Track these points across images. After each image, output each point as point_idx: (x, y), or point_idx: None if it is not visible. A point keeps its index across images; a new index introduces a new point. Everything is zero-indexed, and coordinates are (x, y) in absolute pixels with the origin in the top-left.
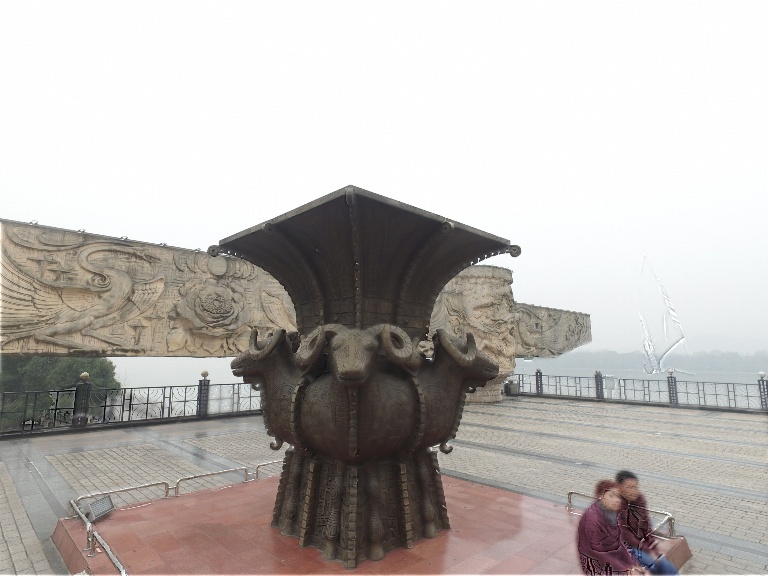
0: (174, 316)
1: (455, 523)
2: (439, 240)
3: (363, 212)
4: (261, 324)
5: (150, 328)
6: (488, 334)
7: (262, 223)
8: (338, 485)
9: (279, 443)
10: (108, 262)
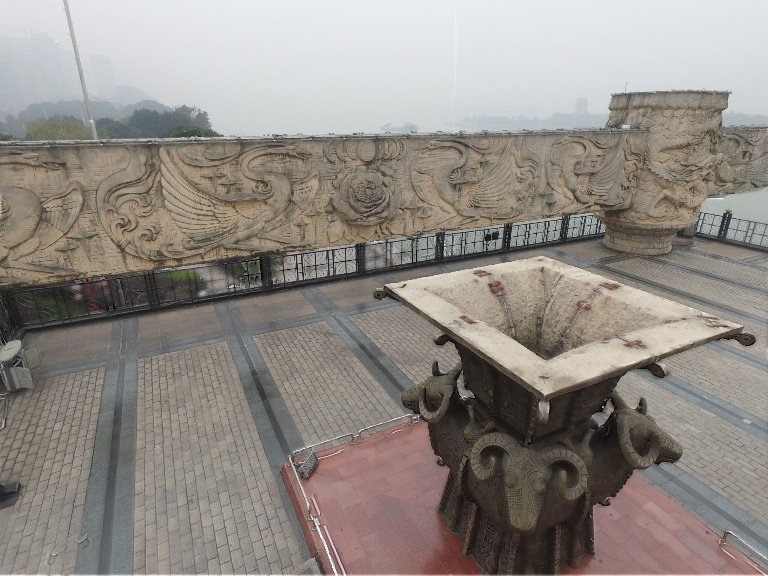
0: (331, 210)
1: (599, 545)
2: None
3: None
4: (412, 205)
5: (312, 224)
6: (672, 183)
7: (432, 319)
8: (498, 540)
9: None
10: (266, 166)
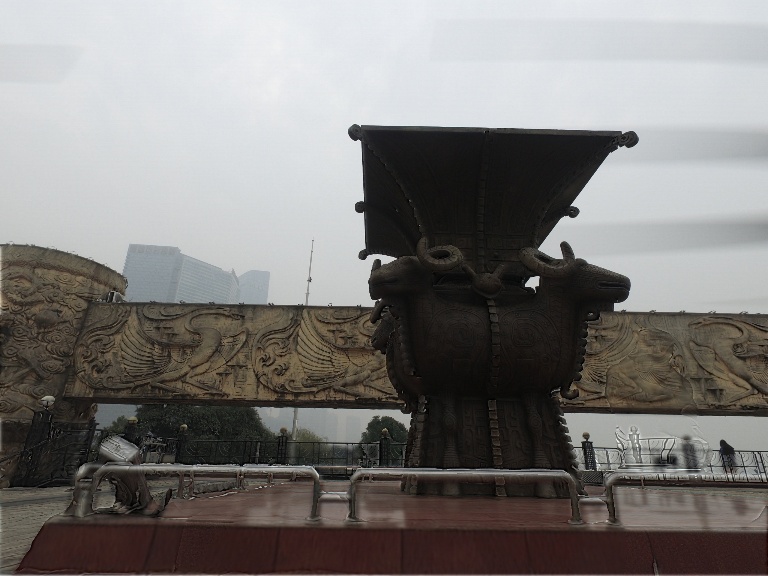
0: None
1: None
2: (502, 157)
3: (387, 147)
4: None
5: None
6: None
7: None
8: None
9: (407, 405)
10: None
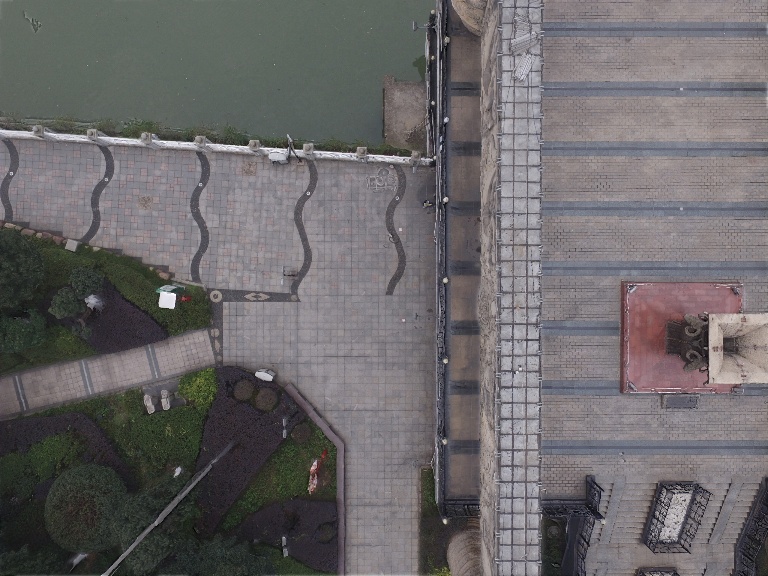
0: None
1: None
2: None
3: None
4: None
5: None
6: None
7: None
8: None
9: None
10: None
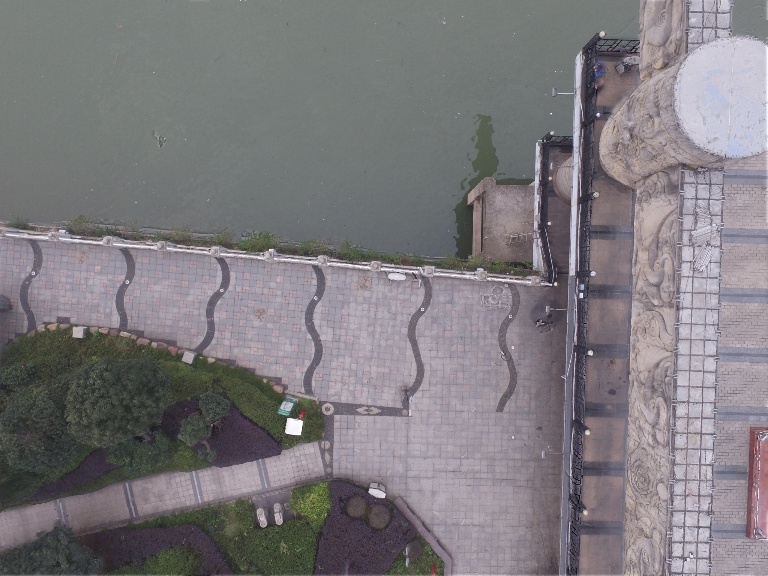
0: None
1: None
2: None
3: None
4: None
5: None
6: None
7: None
8: None
9: None
10: None
